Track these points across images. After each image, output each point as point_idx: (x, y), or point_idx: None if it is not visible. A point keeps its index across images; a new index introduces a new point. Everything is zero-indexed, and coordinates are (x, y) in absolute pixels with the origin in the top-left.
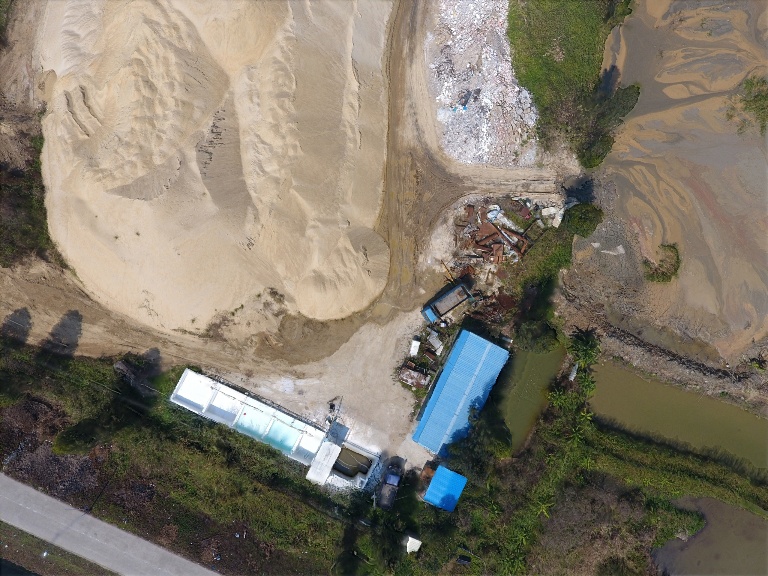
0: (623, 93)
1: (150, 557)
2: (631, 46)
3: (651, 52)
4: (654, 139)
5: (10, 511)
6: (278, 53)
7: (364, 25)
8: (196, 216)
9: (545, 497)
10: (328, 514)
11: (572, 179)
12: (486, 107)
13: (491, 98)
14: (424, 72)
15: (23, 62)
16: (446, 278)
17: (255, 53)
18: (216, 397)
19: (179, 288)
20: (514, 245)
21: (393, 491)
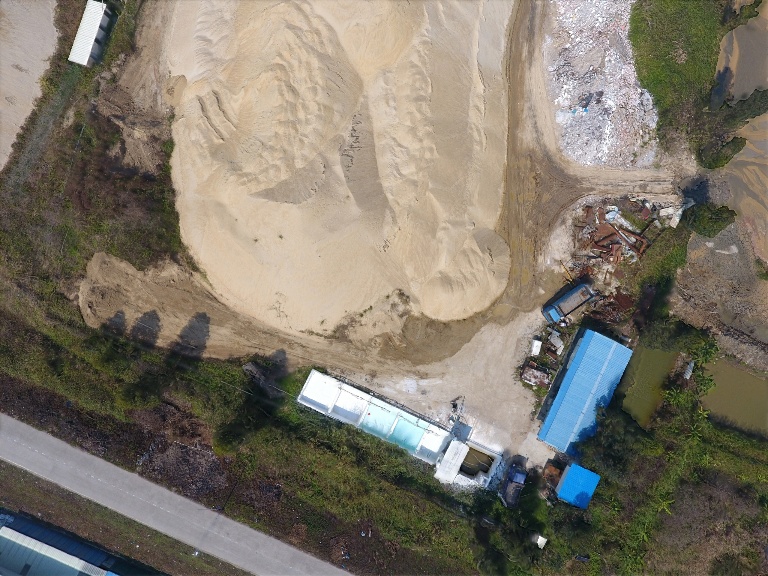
0: (762, 95)
1: (281, 556)
2: (744, 48)
3: (763, 54)
4: (767, 140)
5: (144, 511)
6: (415, 57)
7: (488, 29)
8: (340, 219)
9: (665, 494)
10: (453, 512)
11: (687, 180)
12: (610, 109)
13: (614, 100)
14: (543, 75)
15: (151, 67)
16: (565, 278)
17: (391, 57)
18: (339, 397)
19: (314, 290)
20: (633, 245)
21: (517, 489)
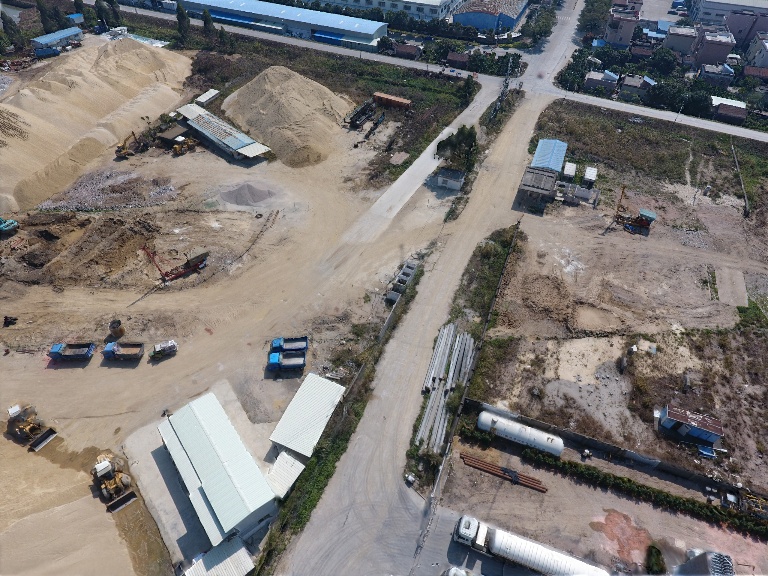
0: None
1: None
2: None
3: None
4: None
5: None
6: None
7: None
8: None
9: None
10: None
11: None
12: None
13: None
14: None
15: None
16: None
17: None
18: None
19: None
20: (6, 62)
21: None
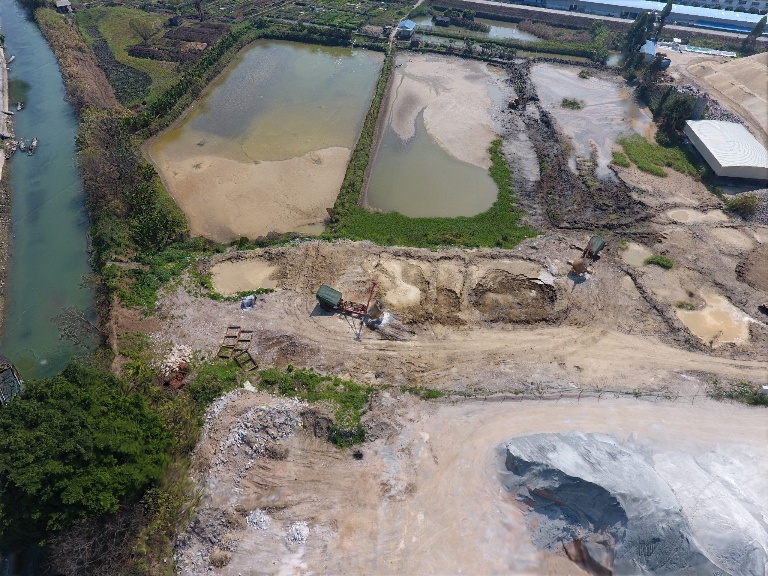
0: None
1: None
2: None
3: None
4: None
5: None
6: None
7: None
8: None
9: None
10: (665, 38)
11: None
12: None
13: None
14: None
15: None
16: None
17: None
18: None
19: None
20: None
21: None
